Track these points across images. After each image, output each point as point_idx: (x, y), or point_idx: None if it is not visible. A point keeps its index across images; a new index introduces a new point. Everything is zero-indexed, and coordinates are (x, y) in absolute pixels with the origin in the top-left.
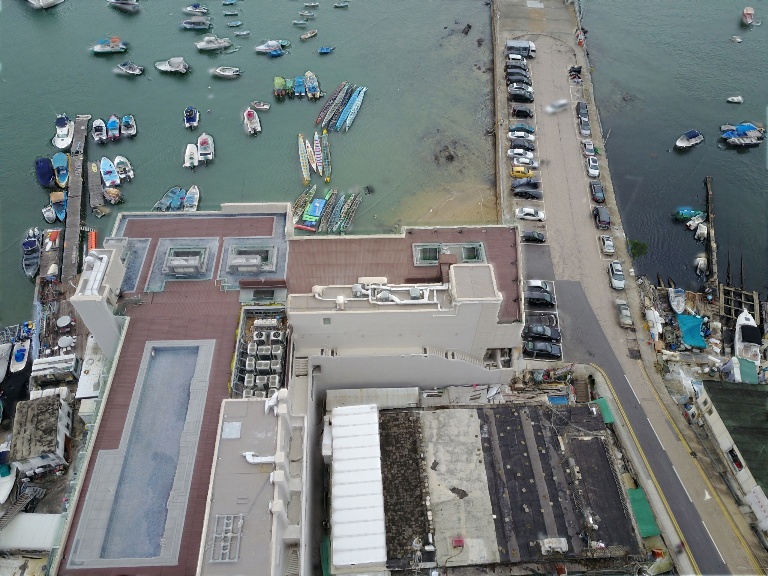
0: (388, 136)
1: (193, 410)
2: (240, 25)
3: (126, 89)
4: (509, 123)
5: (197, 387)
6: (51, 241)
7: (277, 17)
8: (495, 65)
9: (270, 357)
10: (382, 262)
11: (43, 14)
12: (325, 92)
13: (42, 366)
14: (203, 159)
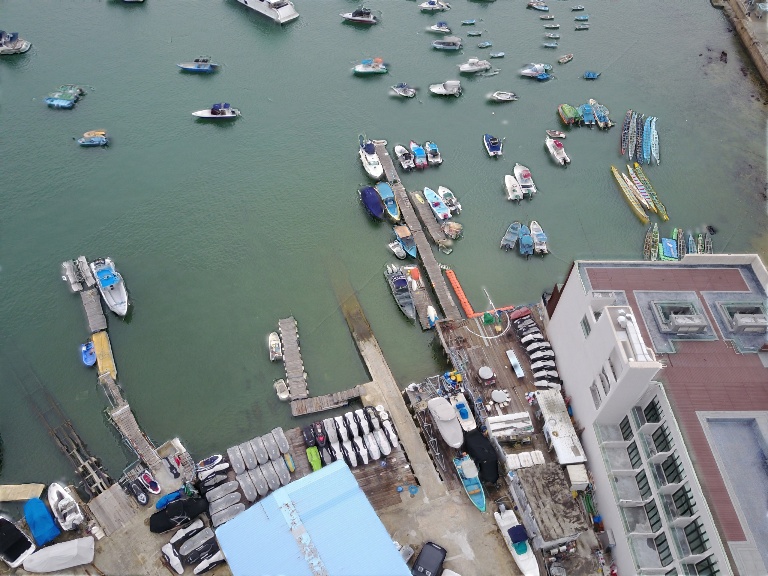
0: (700, 171)
1: None
2: (489, 46)
3: (399, 112)
4: None
5: None
6: (414, 280)
7: (524, 39)
8: None
9: None
10: None
11: (279, 29)
12: (614, 121)
13: (500, 425)
14: (527, 192)
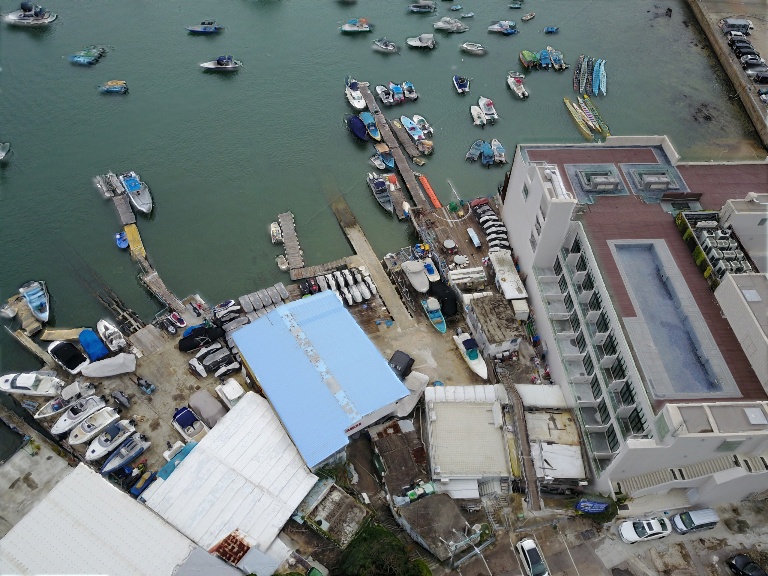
0: (641, 101)
1: (680, 289)
2: (460, 9)
3: (380, 62)
4: (755, 88)
5: (672, 273)
6: (392, 183)
7: (492, 2)
8: (716, 41)
9: (725, 250)
10: (767, 182)
11: None
12: (568, 64)
13: (459, 276)
14: (490, 118)
